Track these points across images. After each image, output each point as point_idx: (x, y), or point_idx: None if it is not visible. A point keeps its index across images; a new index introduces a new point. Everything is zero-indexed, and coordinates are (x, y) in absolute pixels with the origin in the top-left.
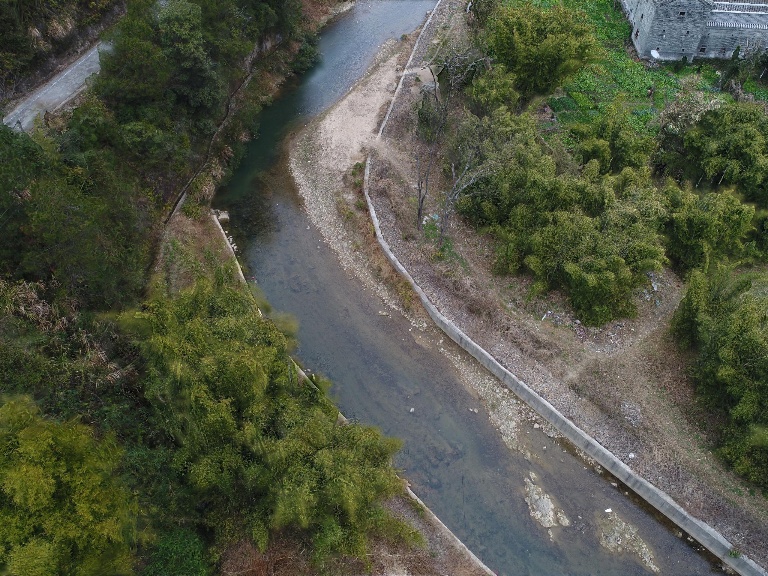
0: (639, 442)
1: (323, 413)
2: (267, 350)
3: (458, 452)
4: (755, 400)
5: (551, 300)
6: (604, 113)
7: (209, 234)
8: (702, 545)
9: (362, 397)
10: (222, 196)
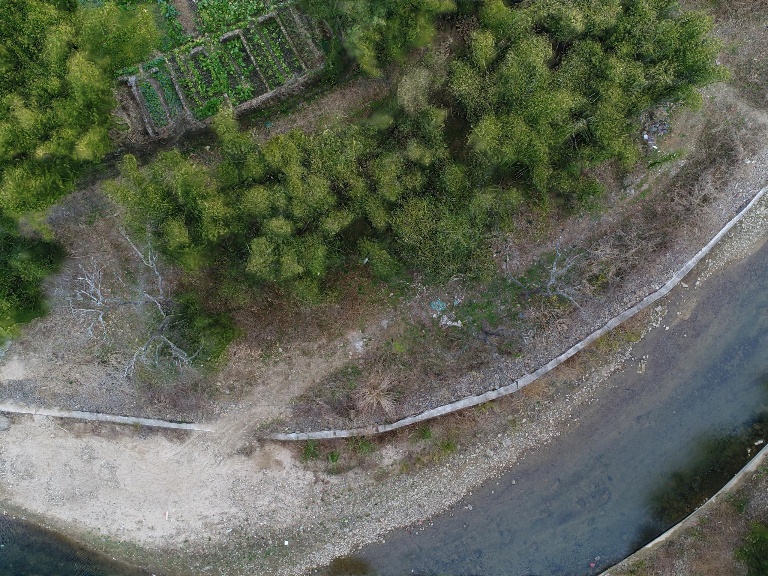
0: None
1: None
2: None
3: None
4: None
5: None
6: None
7: None
8: None
9: None
10: None
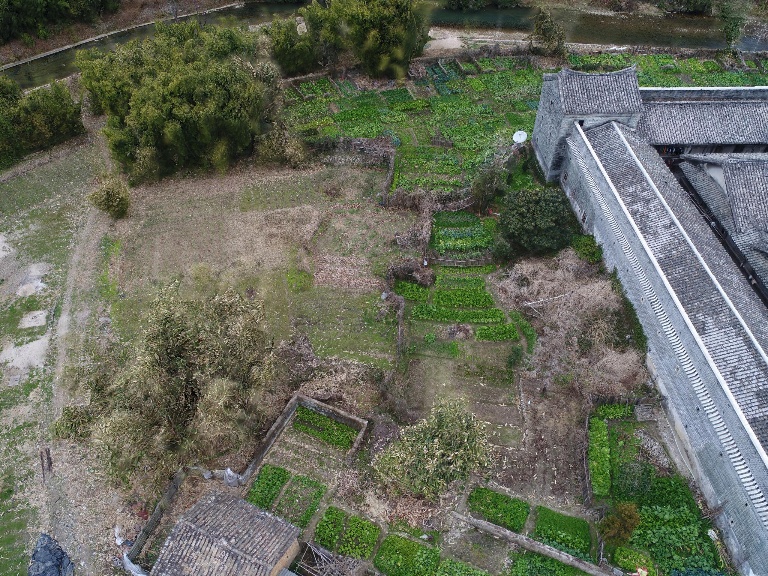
0: None
1: None
2: None
3: (31, 77)
4: None
5: None
6: None
7: (211, 0)
8: None
9: None
10: (262, 5)
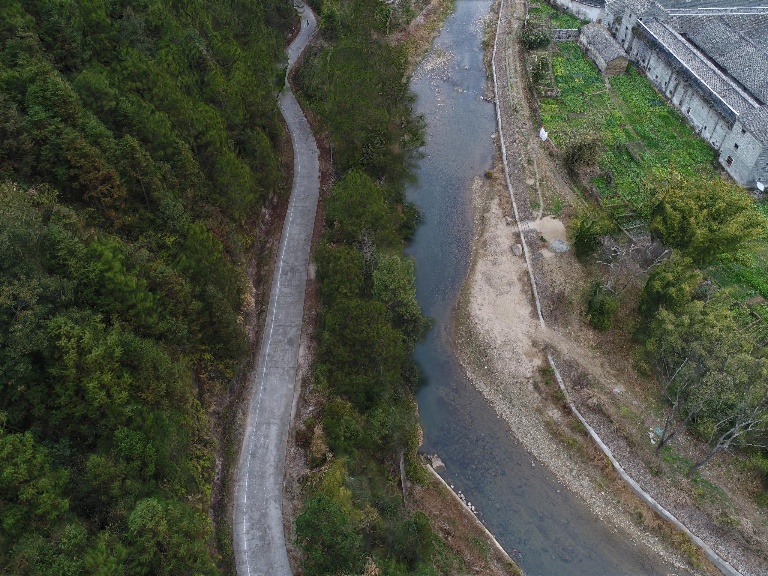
0: None
1: None
2: None
3: None
4: None
5: None
6: (748, 266)
7: (445, 500)
8: None
9: None
10: None
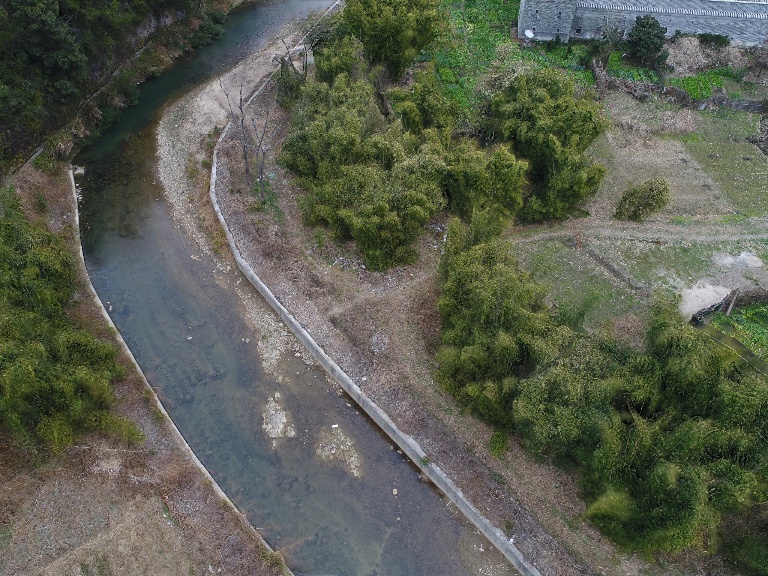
0: (373, 367)
1: (46, 318)
2: (28, 270)
3: (218, 374)
4: (466, 327)
5: (348, 248)
6: (463, 87)
7: (56, 185)
8: (408, 457)
9: (149, 327)
10: (86, 154)
